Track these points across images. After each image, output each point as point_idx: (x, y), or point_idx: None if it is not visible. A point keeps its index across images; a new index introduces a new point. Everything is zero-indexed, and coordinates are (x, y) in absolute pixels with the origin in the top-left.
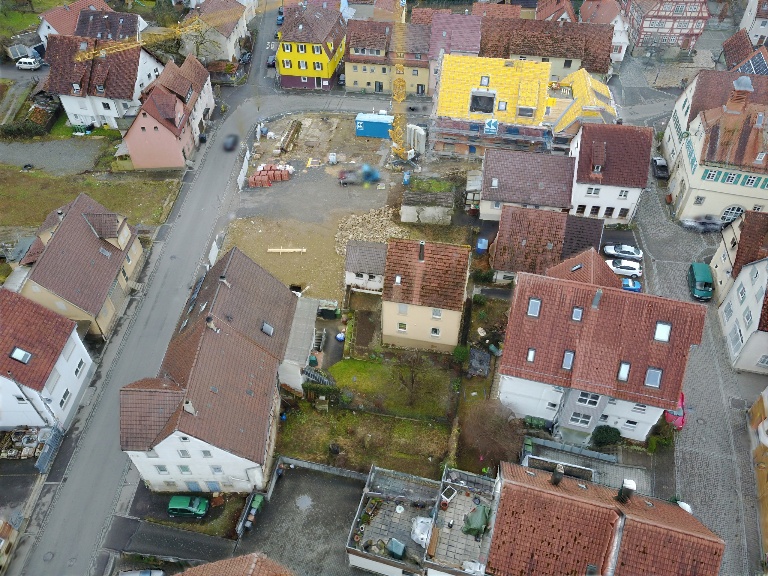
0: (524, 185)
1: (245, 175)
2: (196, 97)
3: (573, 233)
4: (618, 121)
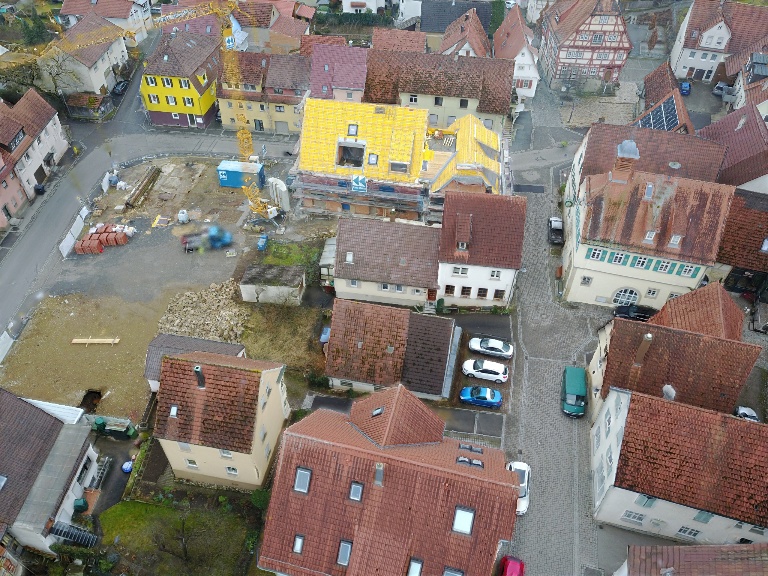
0: (383, 260)
1: (76, 238)
2: (29, 142)
3: (417, 335)
4: (486, 189)
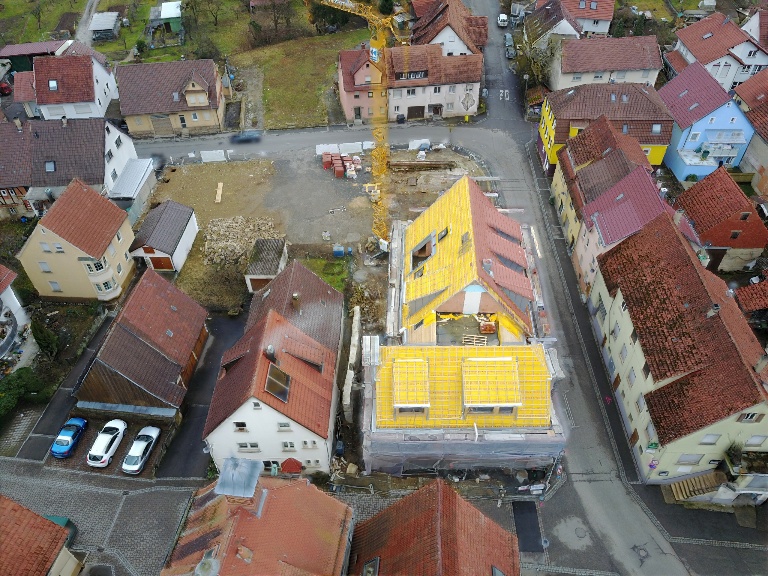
0: None
1: None
2: (421, 84)
3: None
4: None
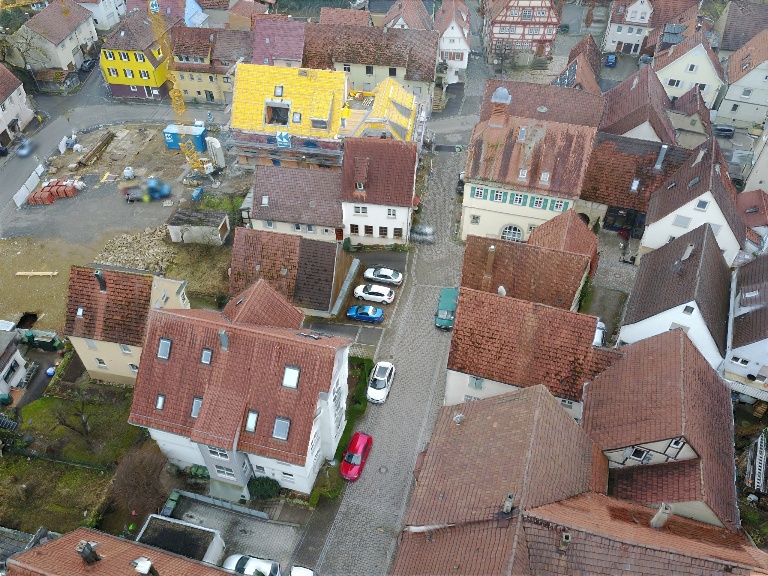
0: (295, 203)
1: (31, 191)
2: None
3: (307, 257)
4: None
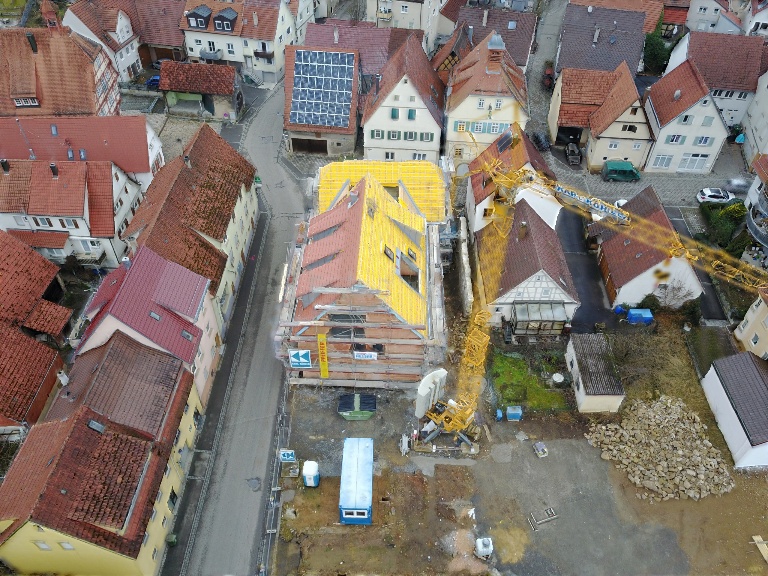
0: None
1: None
2: None
3: None
4: (518, 138)
